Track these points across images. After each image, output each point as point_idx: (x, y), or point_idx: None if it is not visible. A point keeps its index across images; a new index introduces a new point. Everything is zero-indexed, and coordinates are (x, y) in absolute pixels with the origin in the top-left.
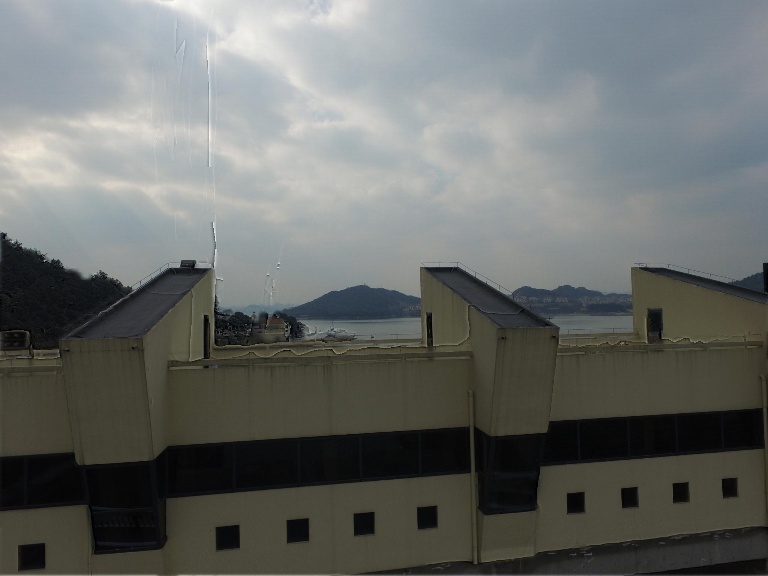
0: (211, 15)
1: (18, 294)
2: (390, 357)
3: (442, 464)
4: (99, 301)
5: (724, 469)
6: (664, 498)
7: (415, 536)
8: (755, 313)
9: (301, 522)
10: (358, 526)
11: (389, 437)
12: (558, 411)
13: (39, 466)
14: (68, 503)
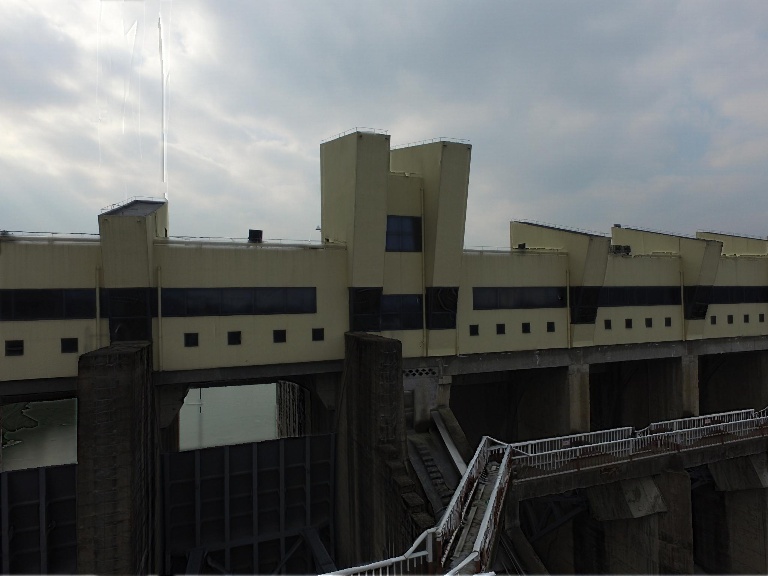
0: None
1: None
2: (751, 258)
3: (764, 299)
4: None
5: None
6: None
7: (759, 324)
8: None
9: (731, 316)
10: (744, 319)
11: None
12: None
13: (667, 291)
14: (675, 304)
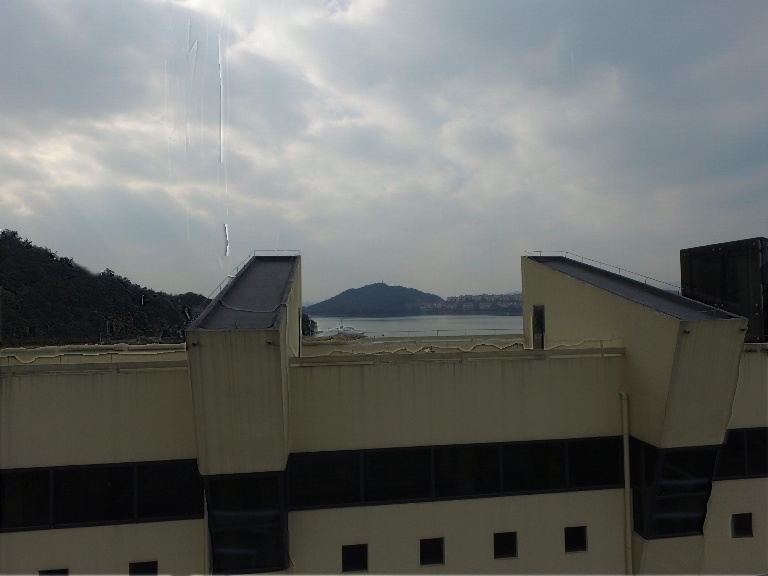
0: (223, 14)
1: (23, 291)
2: (96, 367)
3: (169, 506)
4: (105, 298)
5: (568, 515)
6: (482, 552)
7: None
8: (618, 311)
9: None
10: None
11: (91, 471)
12: (333, 438)
13: None
14: None
